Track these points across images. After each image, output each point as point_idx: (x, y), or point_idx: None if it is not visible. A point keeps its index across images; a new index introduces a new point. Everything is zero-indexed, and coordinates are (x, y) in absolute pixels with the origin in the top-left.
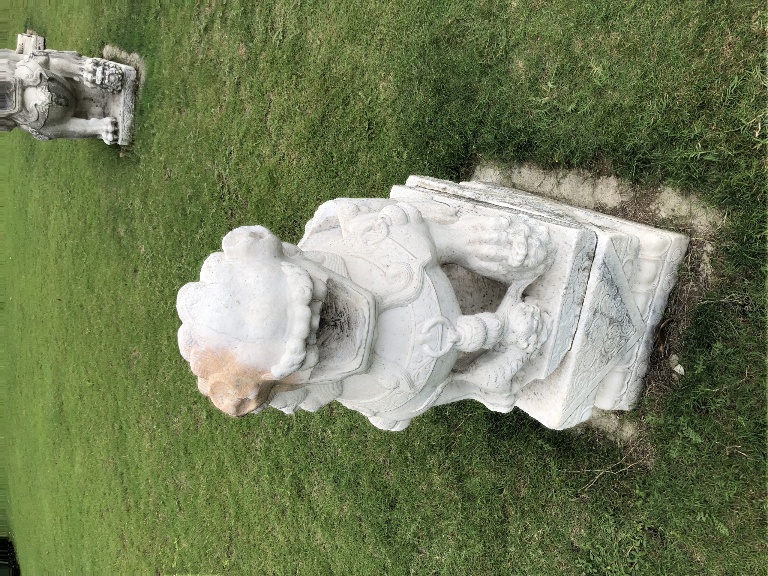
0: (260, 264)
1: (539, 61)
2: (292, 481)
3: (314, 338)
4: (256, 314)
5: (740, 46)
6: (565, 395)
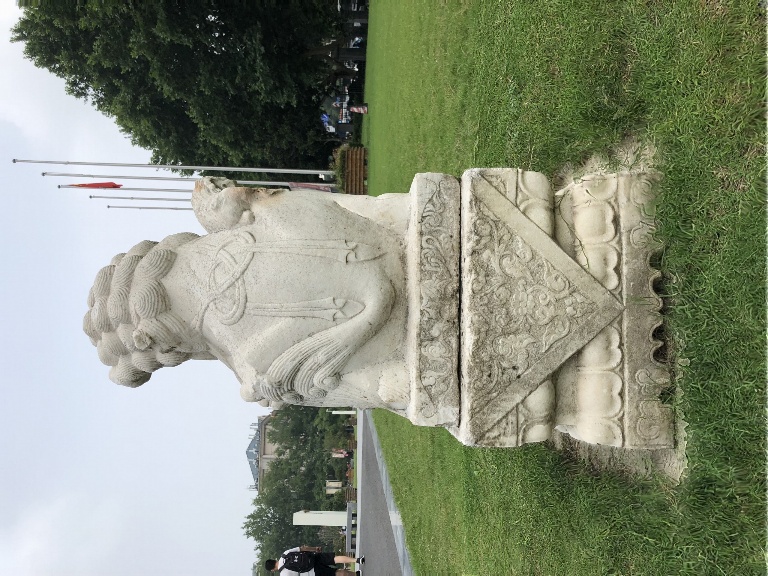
0: None
1: None
2: None
3: None
4: None
5: (533, 568)
6: None
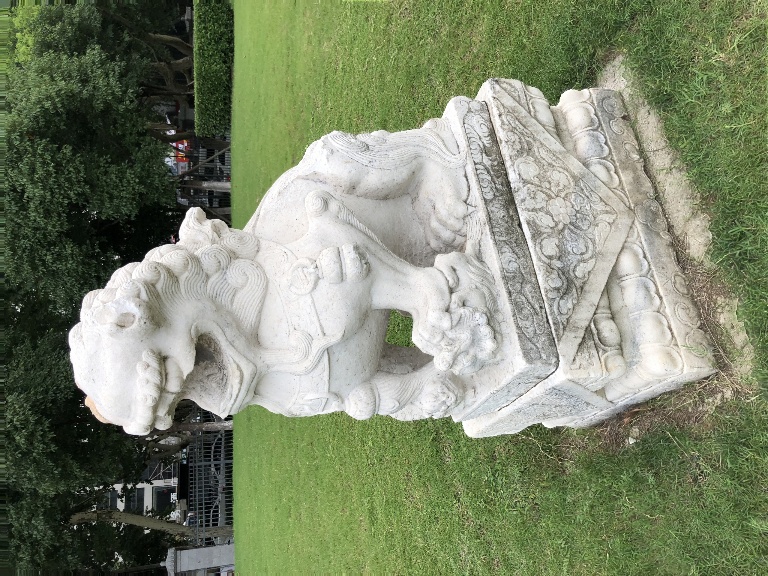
0: (120, 352)
1: None
2: None
3: (166, 414)
4: (104, 400)
5: None
6: (481, 429)
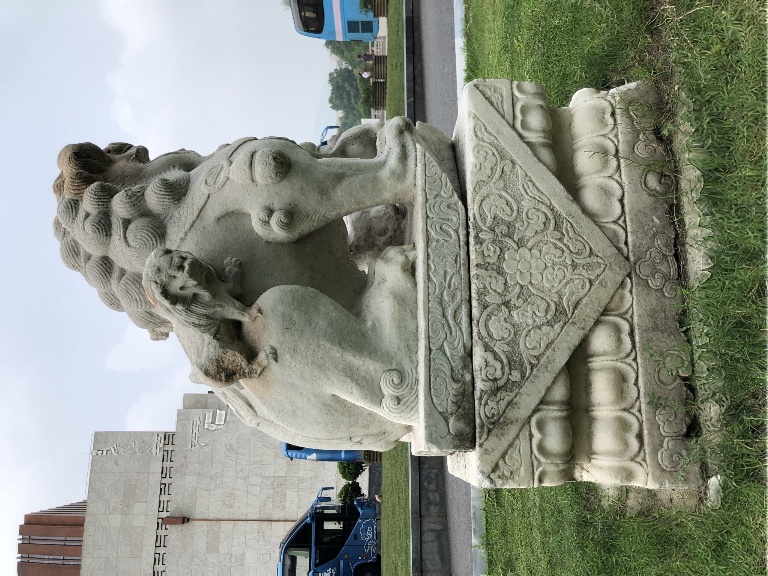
0: None
1: None
2: None
3: None
4: None
5: None
6: None
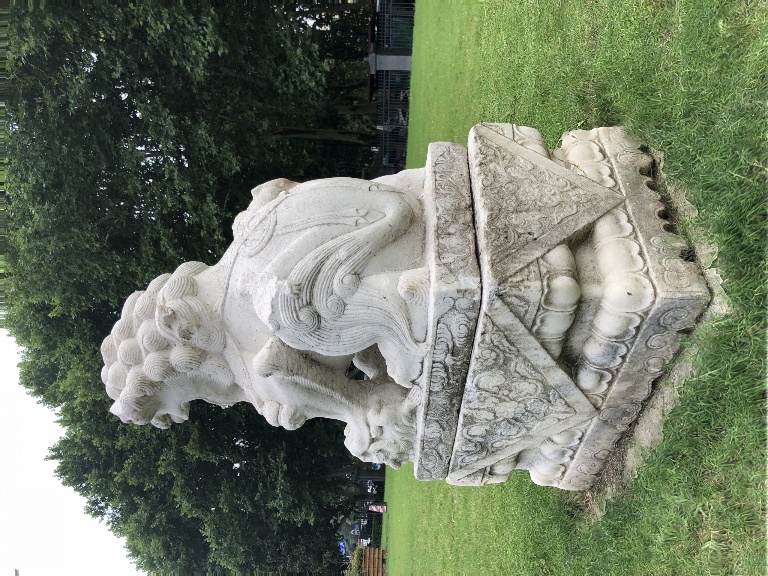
0: None
1: None
2: None
3: None
4: None
5: None
6: None
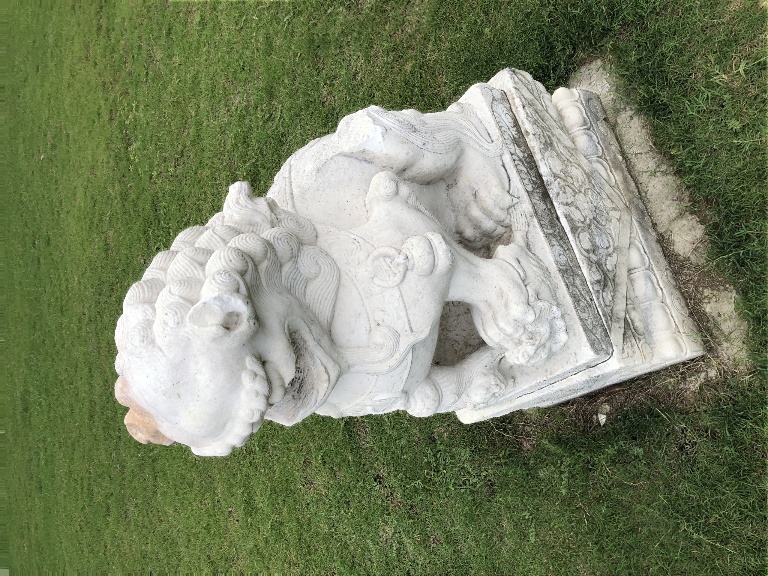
0: (220, 360)
1: (760, 21)
2: (252, 167)
3: None
4: (192, 419)
5: None
6: (486, 416)
